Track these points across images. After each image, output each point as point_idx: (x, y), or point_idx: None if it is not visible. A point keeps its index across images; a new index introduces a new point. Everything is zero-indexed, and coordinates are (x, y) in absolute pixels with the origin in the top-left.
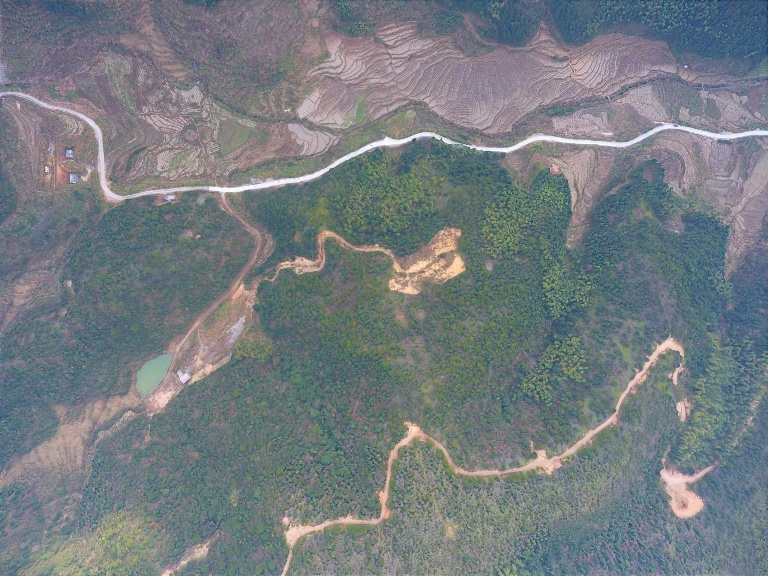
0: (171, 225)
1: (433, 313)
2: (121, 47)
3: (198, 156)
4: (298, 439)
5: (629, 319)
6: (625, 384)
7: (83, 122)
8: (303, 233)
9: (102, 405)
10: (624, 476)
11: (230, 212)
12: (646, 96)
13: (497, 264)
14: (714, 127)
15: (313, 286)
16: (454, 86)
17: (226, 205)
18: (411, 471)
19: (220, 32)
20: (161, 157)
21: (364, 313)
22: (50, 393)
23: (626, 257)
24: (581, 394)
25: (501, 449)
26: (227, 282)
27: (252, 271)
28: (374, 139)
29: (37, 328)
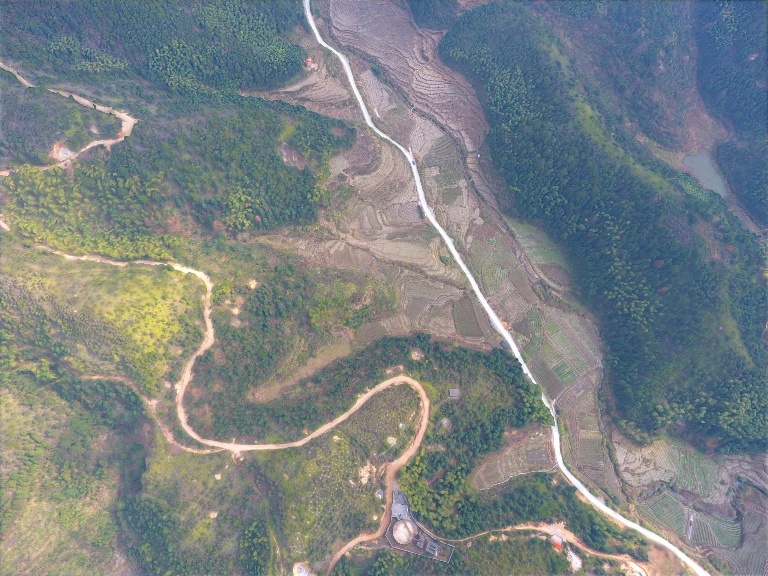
0: None
1: None
2: None
3: None
4: None
5: None
6: (74, 90)
7: None
8: None
9: None
10: None
11: None
12: (432, 135)
13: None
14: (433, 201)
15: None
16: None
17: None
18: None
19: None
20: None
21: None
22: None
23: None
24: (62, 74)
25: None
26: None
27: None
28: None
29: None
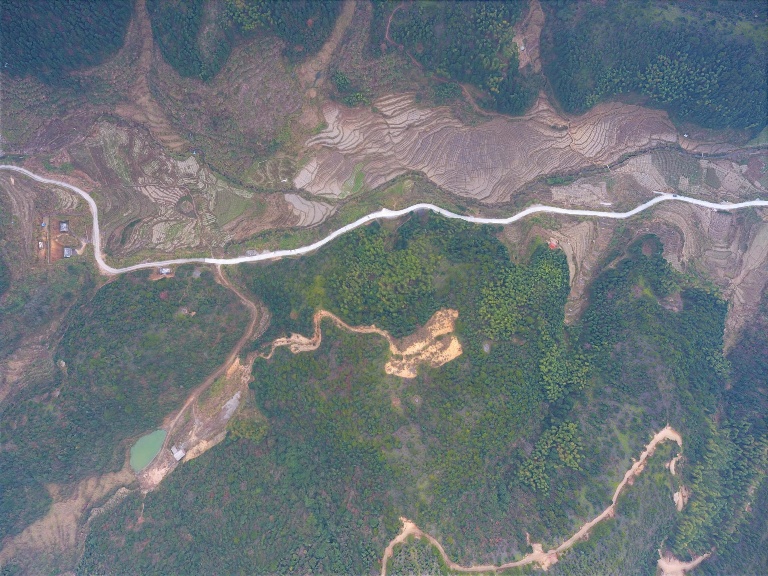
0: (166, 303)
1: (429, 400)
2: (117, 117)
3: (194, 227)
4: (292, 531)
5: (627, 404)
6: (622, 475)
7: (78, 196)
8: (299, 311)
9: (95, 482)
10: (620, 572)
11: (226, 284)
12: (645, 165)
13: (494, 347)
14: (714, 197)
15: (309, 368)
16: (452, 155)
17: (222, 277)
18: (406, 572)
19: (216, 105)
20: (156, 229)
21: (360, 401)
22: (43, 474)
23: (624, 338)
24: (578, 483)
25: (497, 542)
26: (222, 357)
27: (248, 345)
28: (371, 211)
29: (30, 410)
